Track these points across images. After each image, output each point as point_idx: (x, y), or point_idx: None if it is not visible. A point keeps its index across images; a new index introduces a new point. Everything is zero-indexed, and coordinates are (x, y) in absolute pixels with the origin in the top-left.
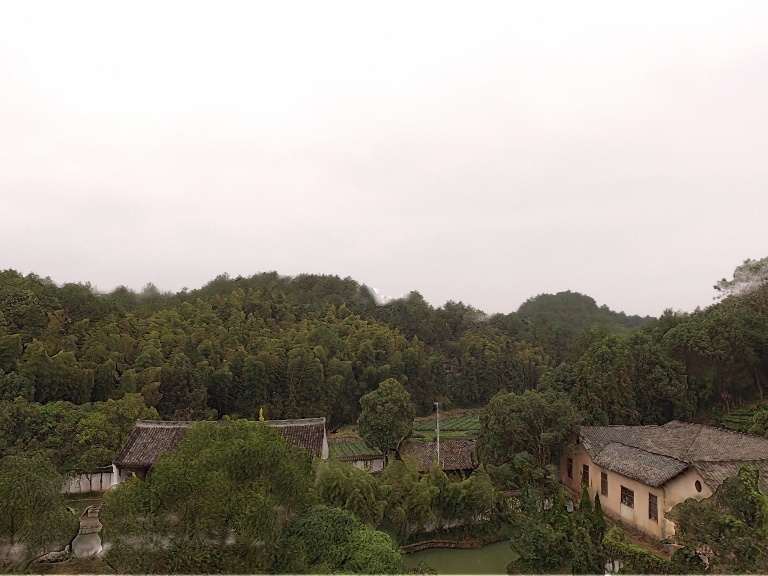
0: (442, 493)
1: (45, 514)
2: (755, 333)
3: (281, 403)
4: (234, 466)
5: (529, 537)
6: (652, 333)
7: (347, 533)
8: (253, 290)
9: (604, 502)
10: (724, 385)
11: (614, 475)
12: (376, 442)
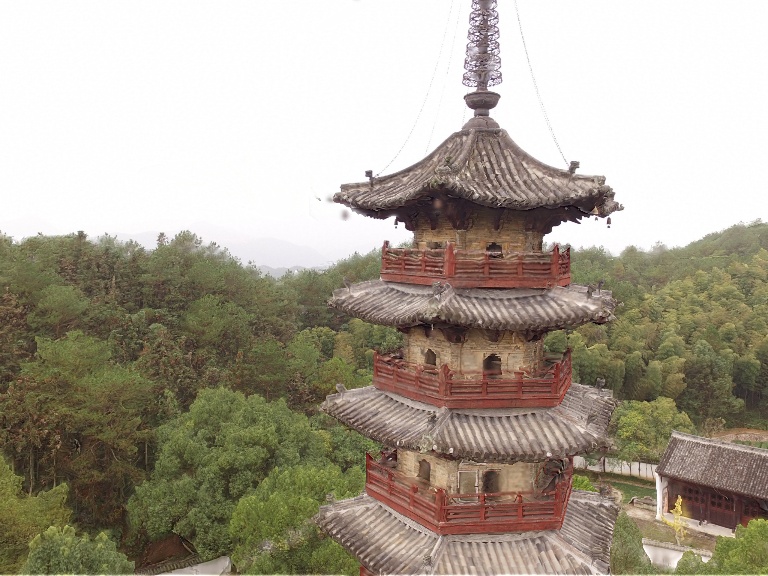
0: None
1: (637, 569)
2: None
3: None
4: None
5: None
6: None
7: None
8: None
9: None
10: None
11: None
12: None
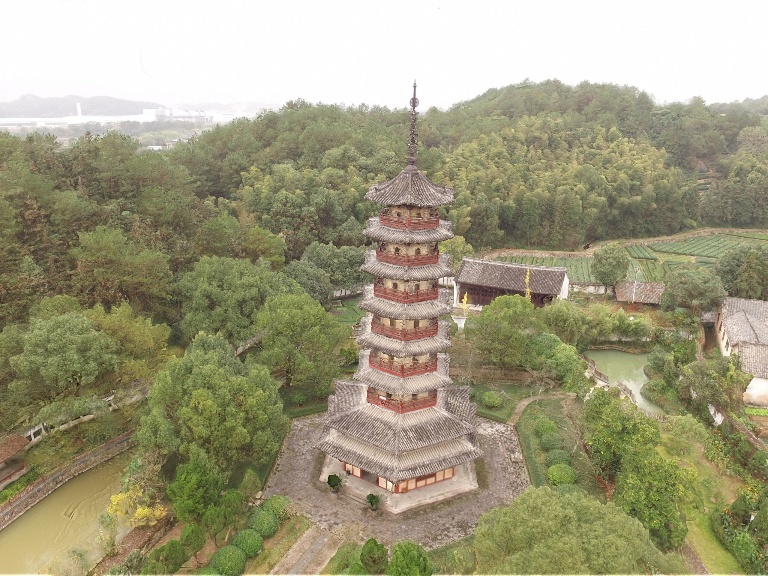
0: (621, 325)
1: None
2: None
3: (548, 226)
4: (513, 319)
5: (652, 357)
6: None
7: (556, 346)
8: (535, 119)
9: (721, 344)
10: None
11: None
12: (600, 279)
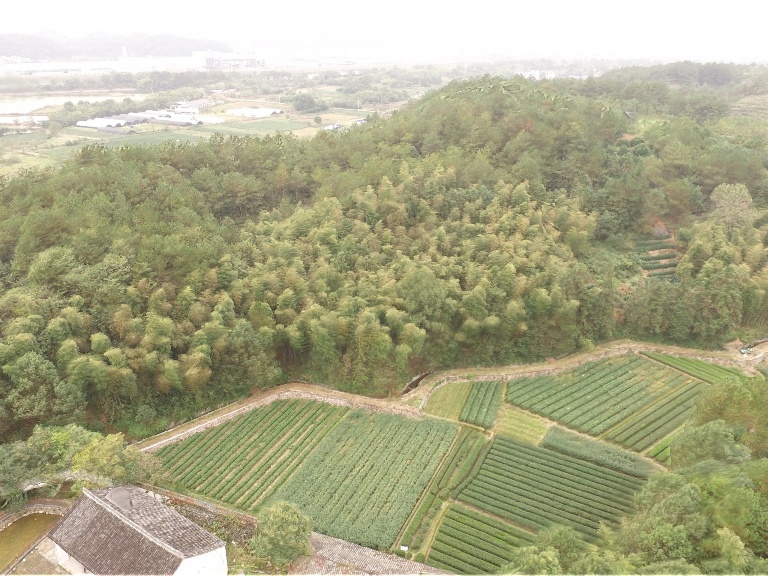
0: None
1: None
2: None
3: (349, 362)
4: None
5: None
6: (616, 573)
7: None
8: (409, 172)
9: None
10: None
11: None
12: None
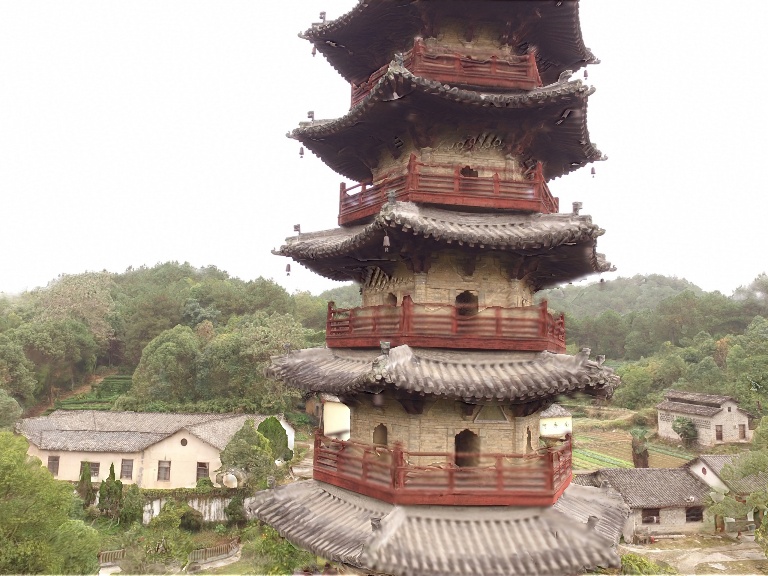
0: None
1: None
2: (82, 337)
3: None
4: None
5: None
6: (6, 333)
7: None
8: None
9: None
10: (53, 380)
11: (74, 454)
12: None
